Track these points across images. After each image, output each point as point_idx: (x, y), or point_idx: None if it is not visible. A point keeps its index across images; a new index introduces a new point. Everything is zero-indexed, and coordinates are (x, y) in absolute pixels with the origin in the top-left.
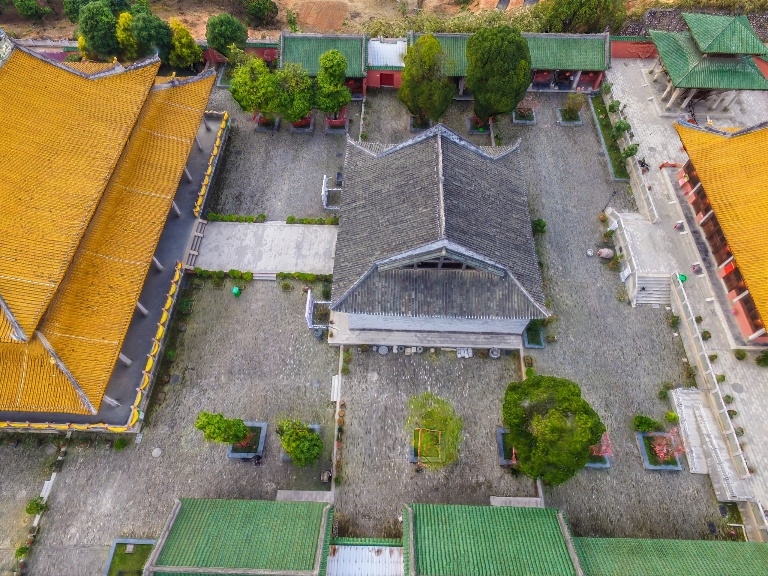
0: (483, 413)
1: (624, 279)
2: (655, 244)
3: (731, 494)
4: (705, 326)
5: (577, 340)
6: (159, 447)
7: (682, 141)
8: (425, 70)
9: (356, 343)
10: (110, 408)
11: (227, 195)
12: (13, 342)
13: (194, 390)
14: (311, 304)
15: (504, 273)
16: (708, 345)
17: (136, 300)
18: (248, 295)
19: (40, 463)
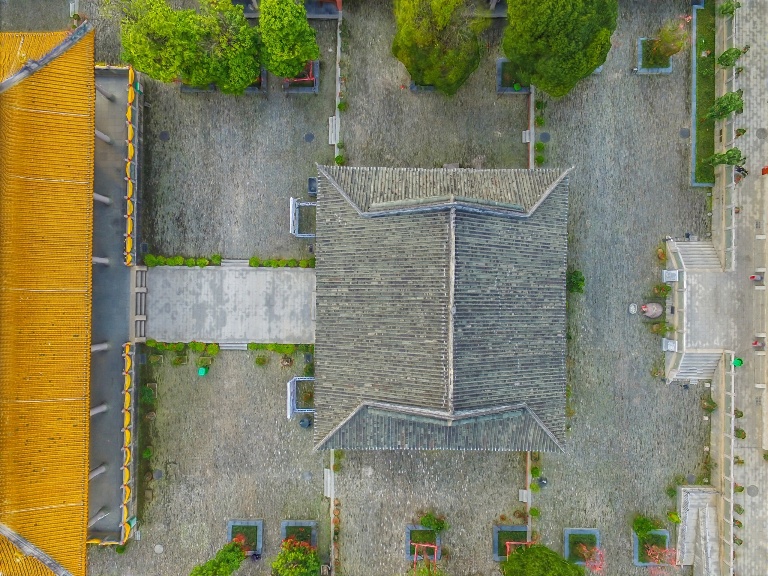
0: (481, 508)
1: (666, 349)
2: (718, 304)
3: None
4: (743, 419)
5: (593, 428)
6: (160, 544)
7: None
8: (436, 32)
9: None
10: None
11: (164, 216)
12: None
13: (181, 486)
14: (293, 383)
15: None
16: (738, 442)
17: (87, 448)
18: (218, 370)
19: None
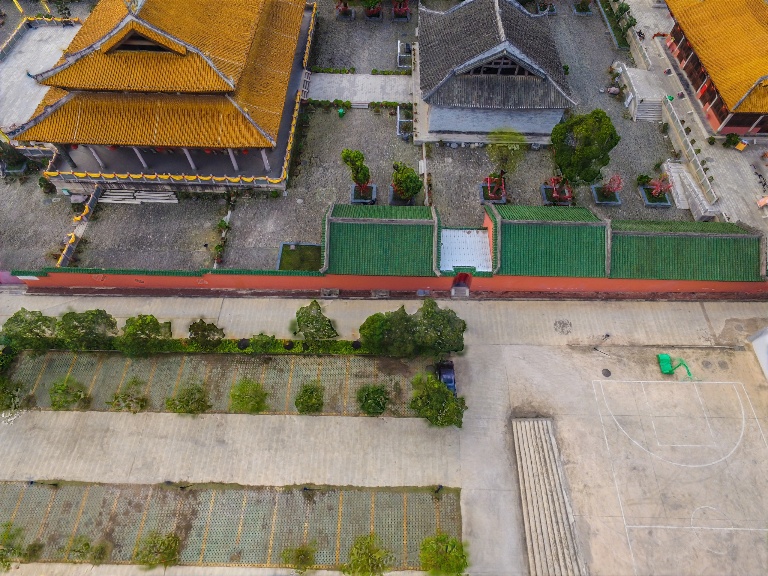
0: (530, 179)
1: (628, 105)
2: (650, 82)
3: (704, 210)
4: None
5: None
6: (301, 198)
7: (669, 8)
8: None
9: (434, 140)
10: (264, 173)
11: (322, 59)
12: (225, 90)
13: (320, 169)
14: None
15: (545, 76)
16: (689, 137)
17: (285, 93)
18: (349, 117)
19: (216, 209)
